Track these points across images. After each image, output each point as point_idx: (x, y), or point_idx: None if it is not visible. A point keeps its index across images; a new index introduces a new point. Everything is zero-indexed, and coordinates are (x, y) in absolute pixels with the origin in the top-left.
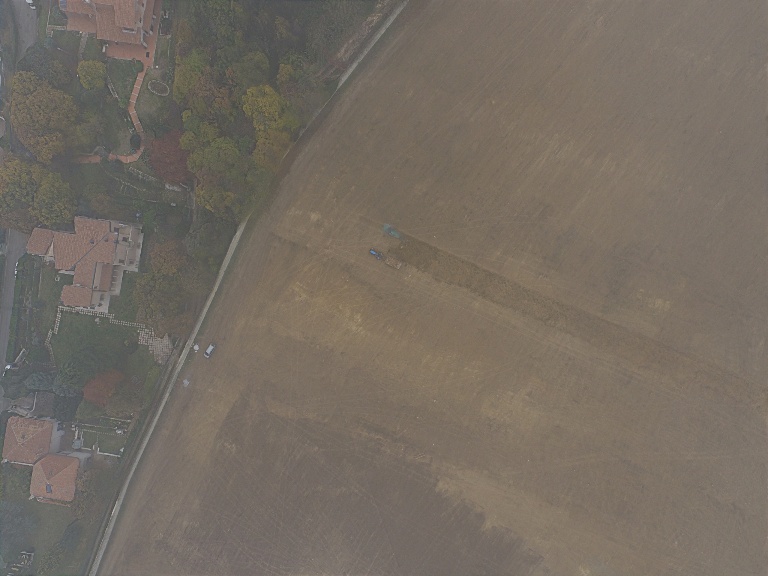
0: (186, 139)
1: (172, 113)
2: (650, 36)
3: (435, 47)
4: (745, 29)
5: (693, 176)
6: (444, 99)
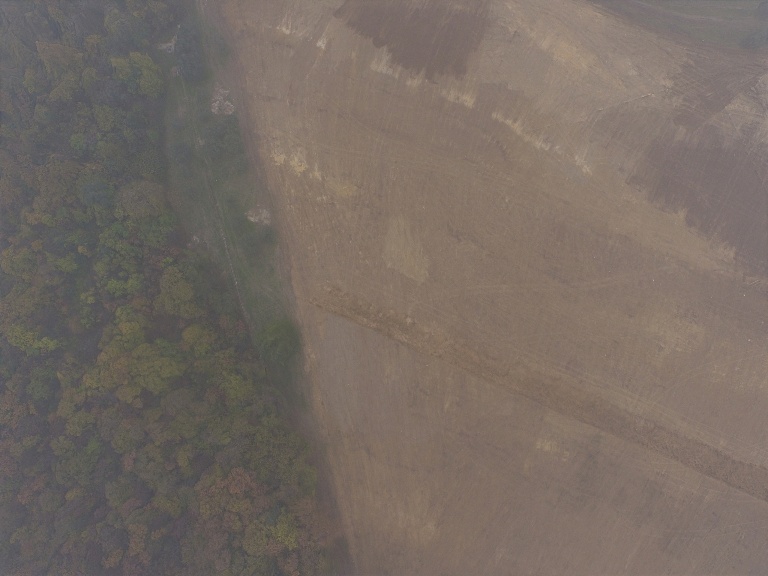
0: None
1: None
2: None
3: None
4: None
5: None
6: None
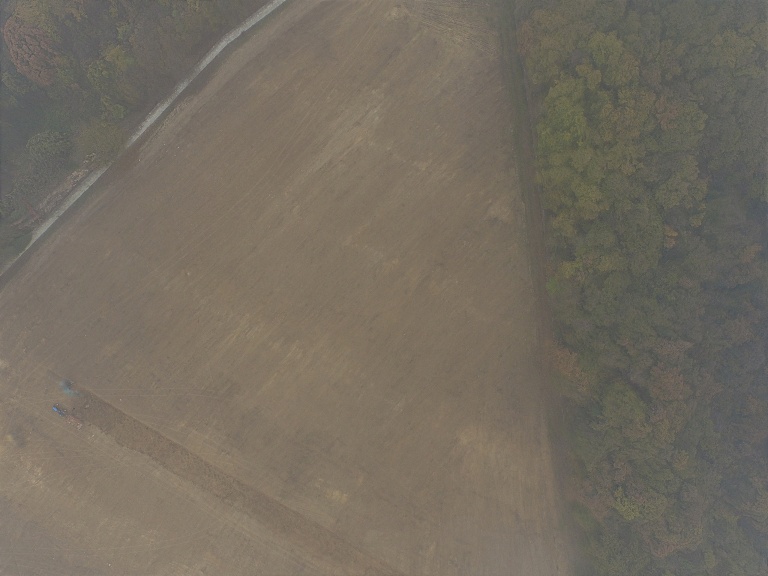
0: None
1: None
2: (342, 231)
3: (136, 211)
4: (432, 238)
5: (376, 374)
6: (141, 264)
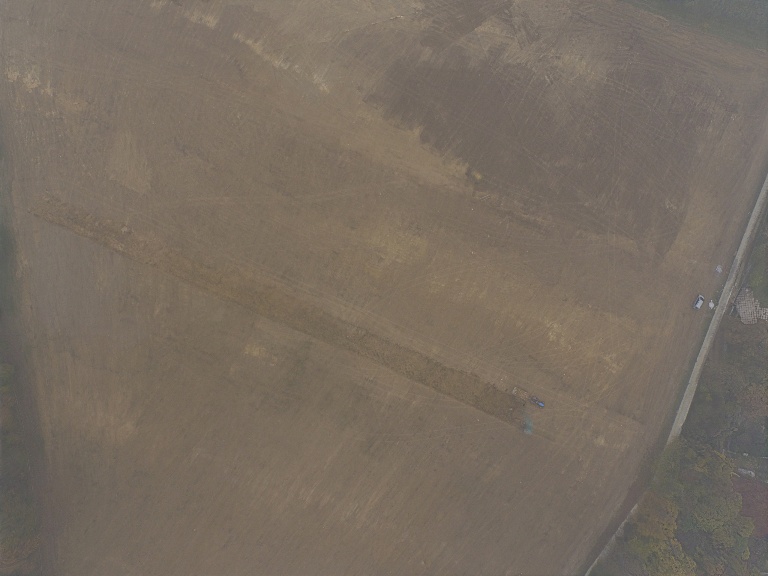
0: (749, 529)
1: (754, 553)
2: None
3: None
4: None
5: (222, 483)
6: (473, 567)
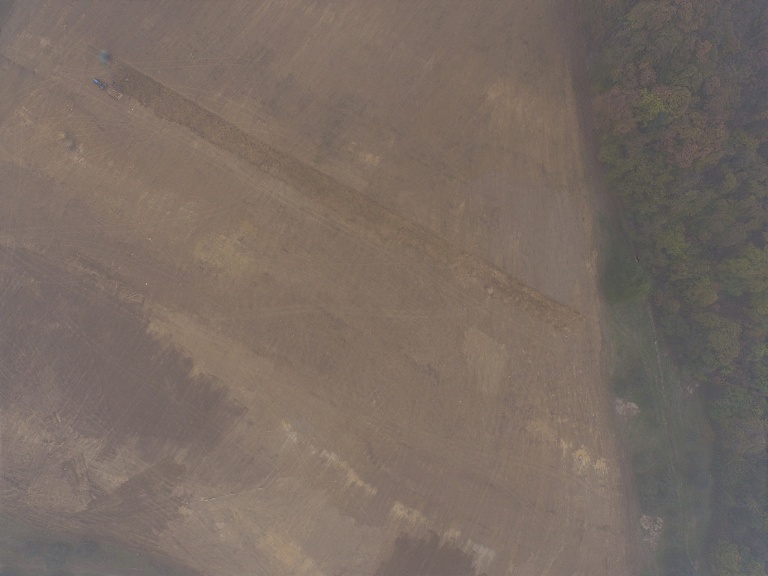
0: None
1: None
2: None
3: None
4: None
5: (406, 33)
6: None
